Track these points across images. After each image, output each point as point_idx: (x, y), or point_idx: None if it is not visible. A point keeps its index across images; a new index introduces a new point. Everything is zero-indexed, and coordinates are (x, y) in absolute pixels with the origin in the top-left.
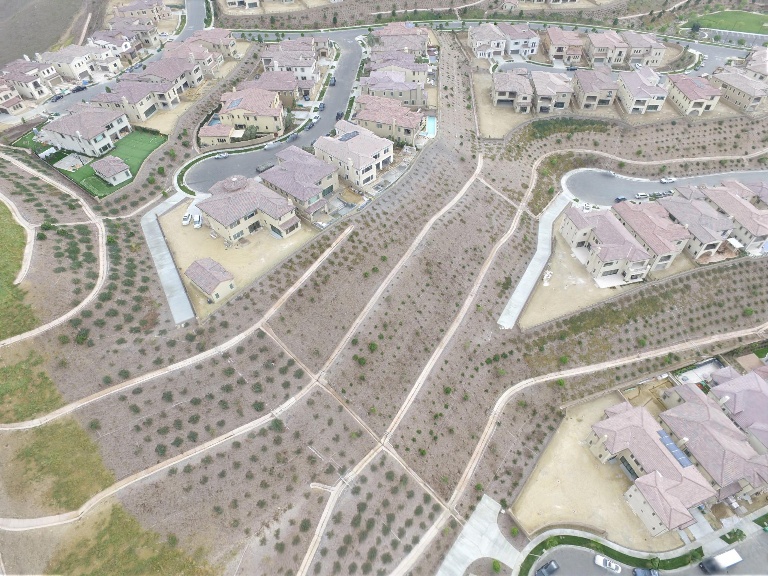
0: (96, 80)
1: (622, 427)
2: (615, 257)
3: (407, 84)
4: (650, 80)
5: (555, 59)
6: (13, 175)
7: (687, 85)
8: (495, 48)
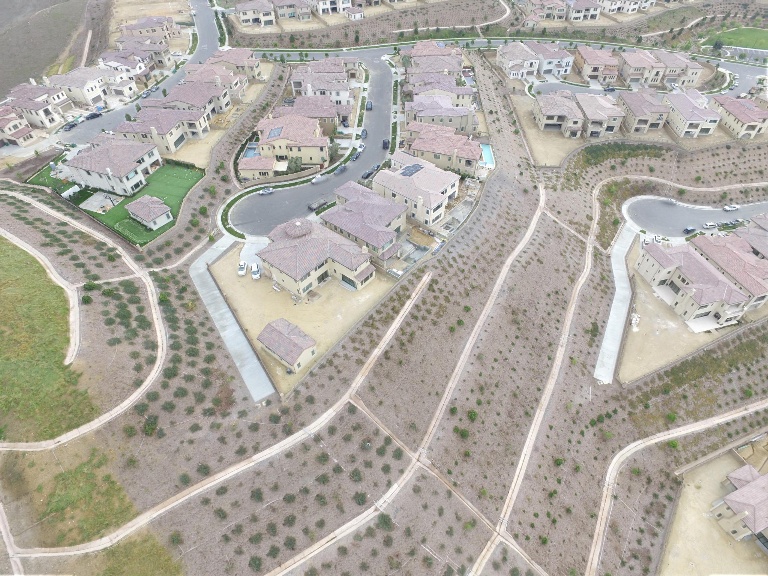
0: (111, 105)
1: (759, 500)
2: (711, 299)
3: (457, 110)
4: (698, 102)
5: (590, 79)
6: (38, 221)
7: (736, 107)
8: (528, 68)
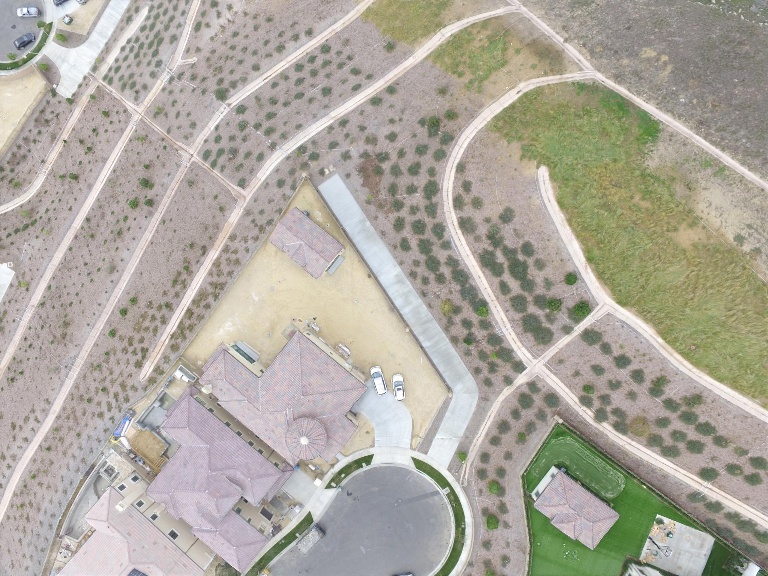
0: None
1: None
2: None
3: None
4: None
5: None
6: (751, 475)
7: None
8: None
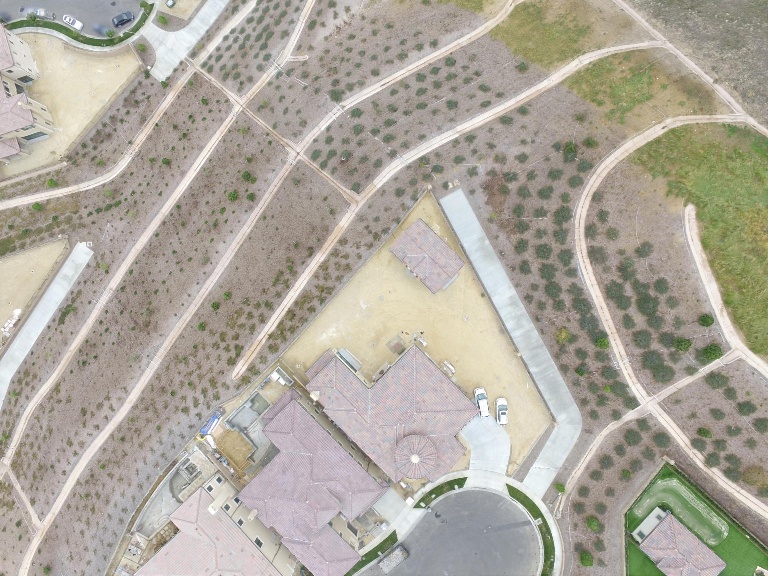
0: None
1: (2, 116)
2: None
3: None
4: None
5: None
6: None
7: None
8: None
